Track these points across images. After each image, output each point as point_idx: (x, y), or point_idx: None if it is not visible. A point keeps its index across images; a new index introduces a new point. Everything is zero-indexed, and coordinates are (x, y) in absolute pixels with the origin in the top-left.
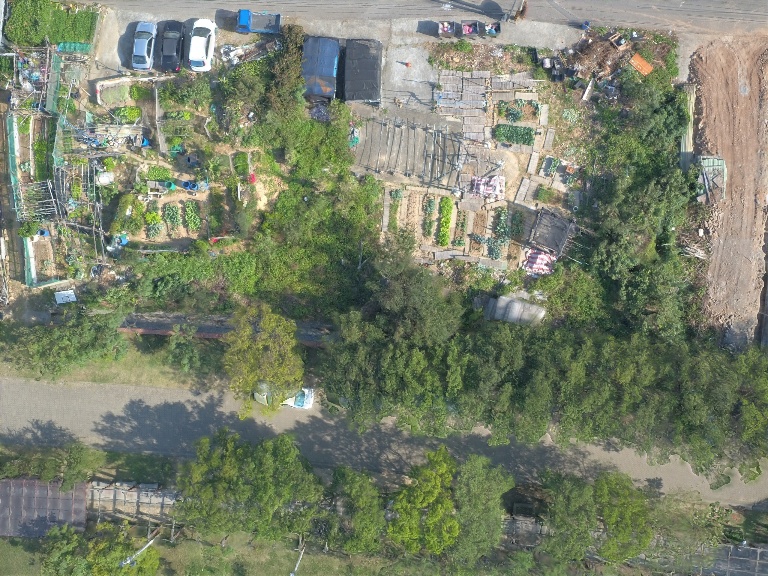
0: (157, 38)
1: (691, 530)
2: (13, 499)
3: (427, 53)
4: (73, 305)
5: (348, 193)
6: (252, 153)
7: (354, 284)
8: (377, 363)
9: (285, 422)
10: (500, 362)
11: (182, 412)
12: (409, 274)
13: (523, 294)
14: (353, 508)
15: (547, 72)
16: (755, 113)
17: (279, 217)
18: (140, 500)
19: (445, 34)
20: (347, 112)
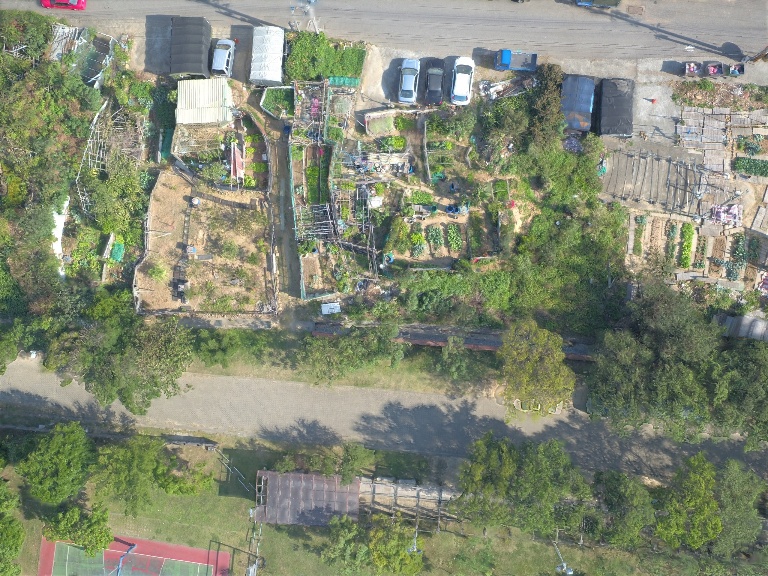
0: (419, 74)
1: None
2: (292, 491)
3: (671, 91)
4: (336, 316)
5: (599, 218)
6: (509, 180)
7: (601, 301)
8: (647, 375)
9: (533, 426)
10: (761, 377)
11: (438, 415)
12: (667, 295)
13: (759, 313)
14: (624, 506)
15: None
16: None
17: (535, 239)
18: (398, 494)
19: (691, 74)
20: (601, 145)
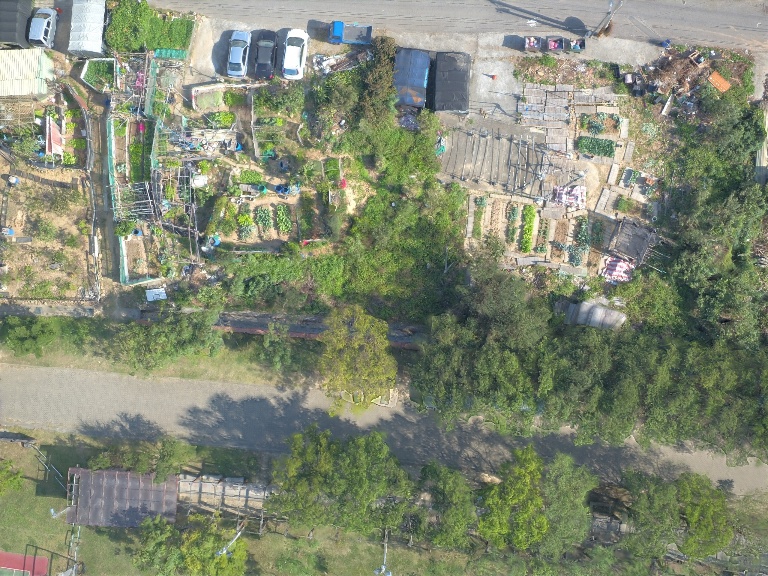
0: (251, 46)
1: None
2: (106, 490)
3: (512, 66)
4: (163, 303)
5: (435, 200)
6: (342, 159)
7: (439, 287)
8: (470, 364)
9: (368, 420)
10: (589, 365)
11: (268, 408)
12: (498, 279)
13: (602, 300)
14: (445, 503)
15: (628, 87)
16: None
17: (368, 221)
18: (225, 493)
19: (531, 49)
20: (436, 122)
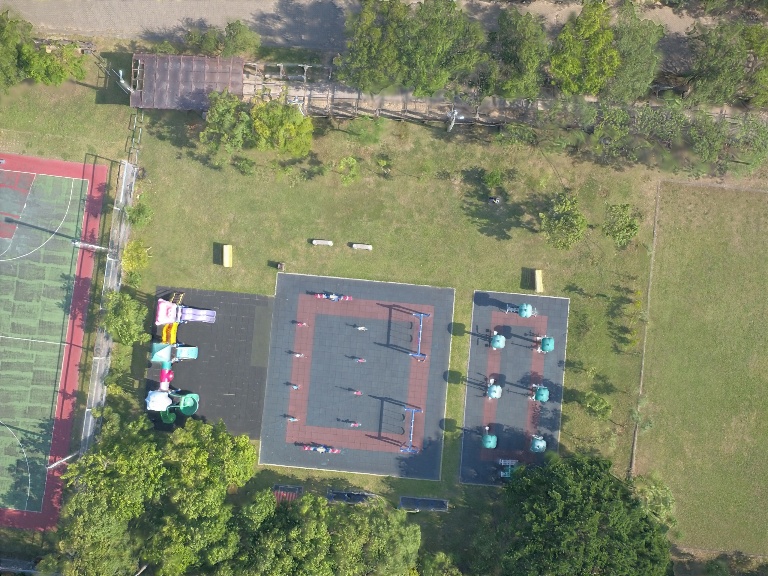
0: None
1: None
2: (171, 73)
3: None
4: None
5: None
6: None
7: None
8: None
9: None
10: None
11: (330, 9)
12: None
13: None
14: (516, 43)
15: None
16: None
17: None
18: (288, 93)
19: None
20: None
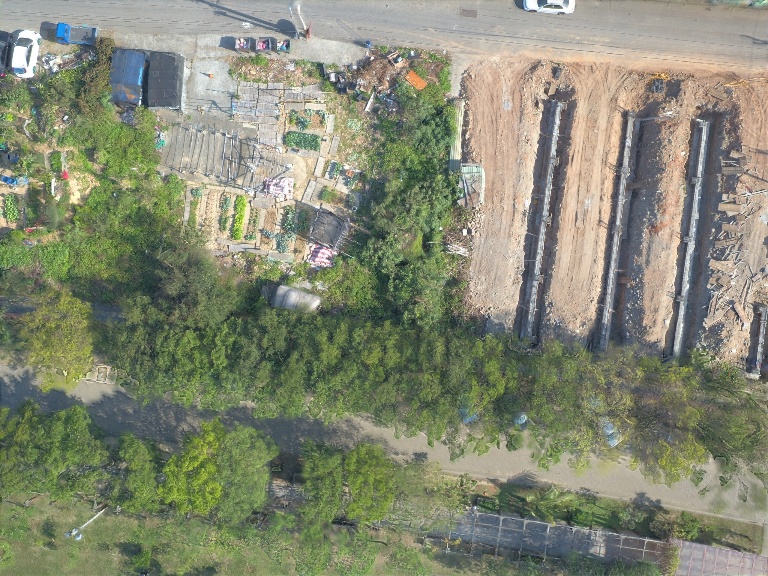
0: None
1: (424, 495)
2: None
3: (228, 66)
4: None
5: (151, 190)
6: (67, 152)
7: None
8: (154, 342)
9: (93, 396)
10: (262, 343)
11: (1, 385)
12: (193, 264)
13: (306, 284)
14: (128, 471)
15: (334, 85)
16: (516, 126)
17: (89, 210)
18: None
19: (242, 49)
20: (151, 117)
